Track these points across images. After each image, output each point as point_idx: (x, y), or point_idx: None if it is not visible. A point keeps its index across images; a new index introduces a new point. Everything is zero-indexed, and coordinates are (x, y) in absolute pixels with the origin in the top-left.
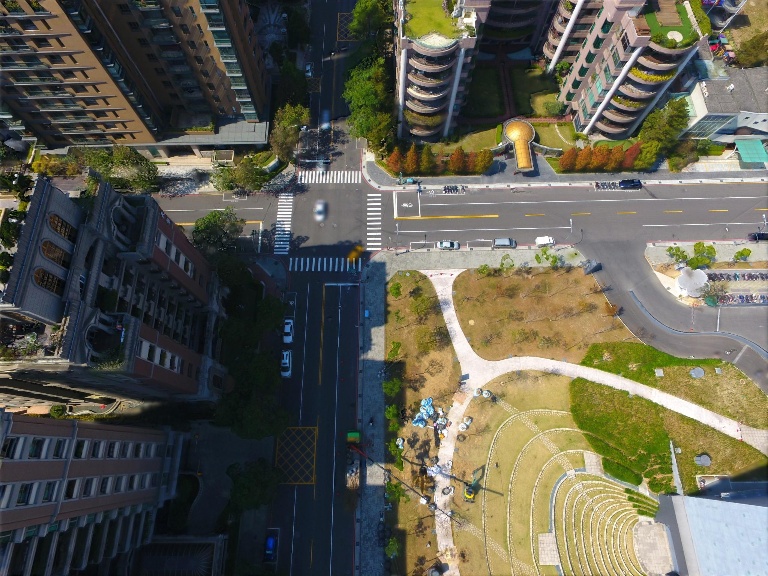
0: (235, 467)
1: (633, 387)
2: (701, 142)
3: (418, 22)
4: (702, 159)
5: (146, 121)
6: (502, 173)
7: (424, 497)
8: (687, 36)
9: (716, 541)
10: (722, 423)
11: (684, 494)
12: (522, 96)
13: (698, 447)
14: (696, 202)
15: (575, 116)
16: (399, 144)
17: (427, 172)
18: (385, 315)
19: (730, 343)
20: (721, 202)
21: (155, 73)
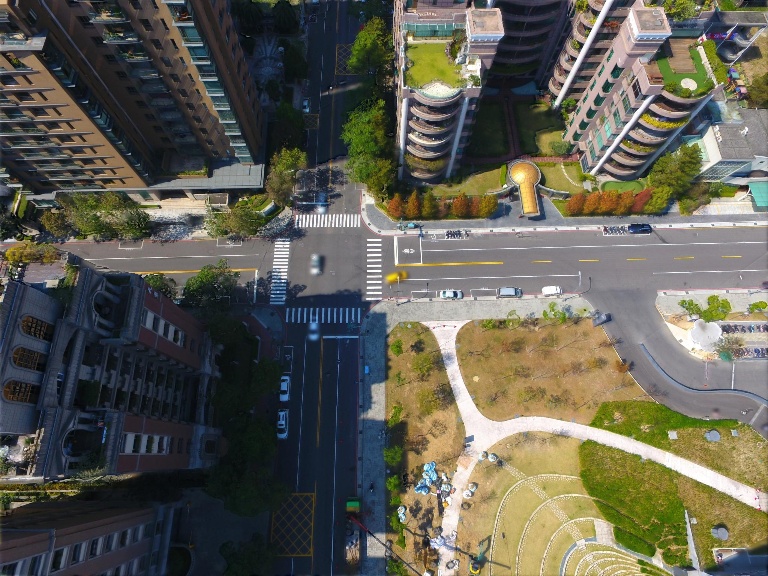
0: (228, 546)
1: (645, 451)
2: (713, 185)
3: (420, 69)
4: (714, 201)
5: (136, 167)
6: (507, 216)
7: (427, 572)
8: (702, 84)
9: None
10: (739, 490)
11: (700, 569)
12: (527, 134)
13: (714, 517)
14: (708, 247)
15: (582, 156)
16: (400, 186)
17: (429, 216)
18: (386, 370)
19: (746, 402)
20: (734, 247)
21: (145, 119)
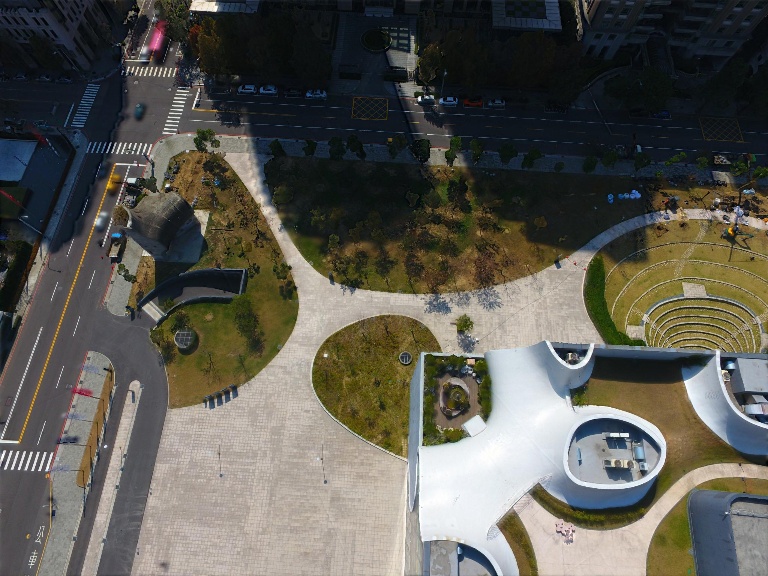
0: None
1: None
2: None
3: None
4: None
5: None
6: None
7: None
8: None
9: None
10: None
11: None
12: None
13: None
14: None
15: None
16: None
17: None
18: None
19: None
20: None
21: None
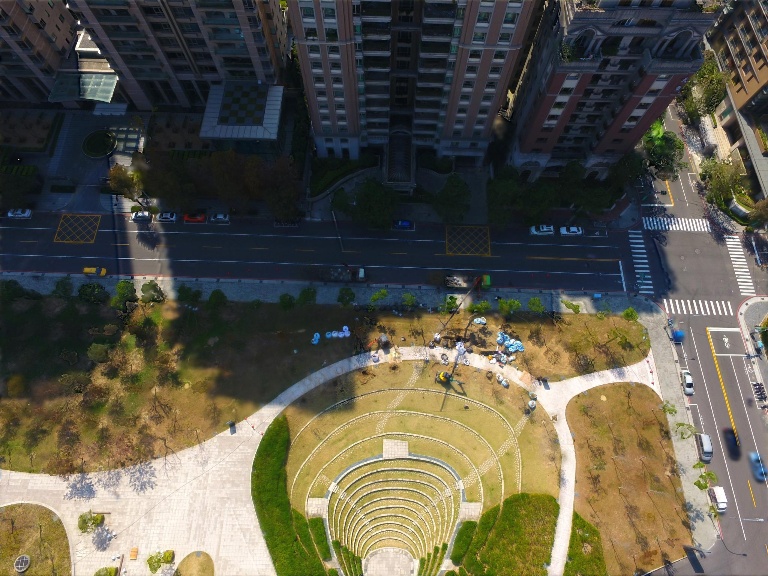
0: (466, 185)
1: (556, 573)
2: None
3: None
4: None
5: (761, 93)
6: None
7: None
8: None
9: None
10: None
11: None
12: None
13: None
14: None
15: None
16: None
17: None
18: None
19: None
20: None
21: None
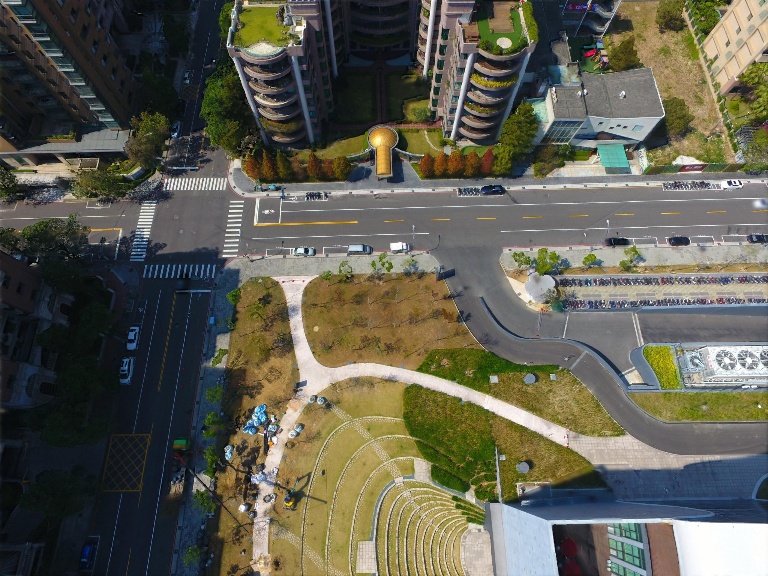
0: (43, 475)
1: (467, 394)
2: (561, 147)
3: (249, 31)
4: (568, 164)
5: (0, 130)
6: (366, 179)
7: (243, 505)
8: (516, 43)
9: (515, 549)
10: (550, 430)
11: (502, 502)
12: (395, 102)
13: (523, 454)
14: (557, 207)
15: (443, 122)
16: (266, 151)
17: (288, 179)
18: (232, 322)
19: (570, 349)
20: (582, 207)
21: (4, 82)
